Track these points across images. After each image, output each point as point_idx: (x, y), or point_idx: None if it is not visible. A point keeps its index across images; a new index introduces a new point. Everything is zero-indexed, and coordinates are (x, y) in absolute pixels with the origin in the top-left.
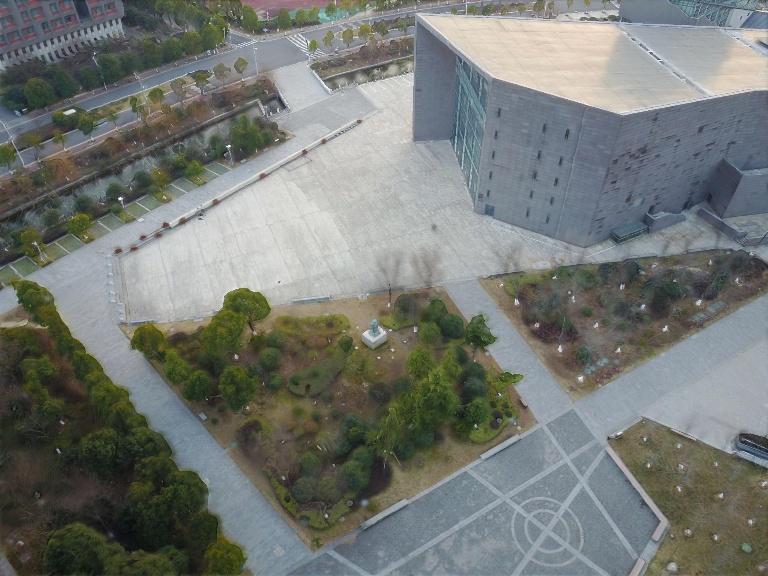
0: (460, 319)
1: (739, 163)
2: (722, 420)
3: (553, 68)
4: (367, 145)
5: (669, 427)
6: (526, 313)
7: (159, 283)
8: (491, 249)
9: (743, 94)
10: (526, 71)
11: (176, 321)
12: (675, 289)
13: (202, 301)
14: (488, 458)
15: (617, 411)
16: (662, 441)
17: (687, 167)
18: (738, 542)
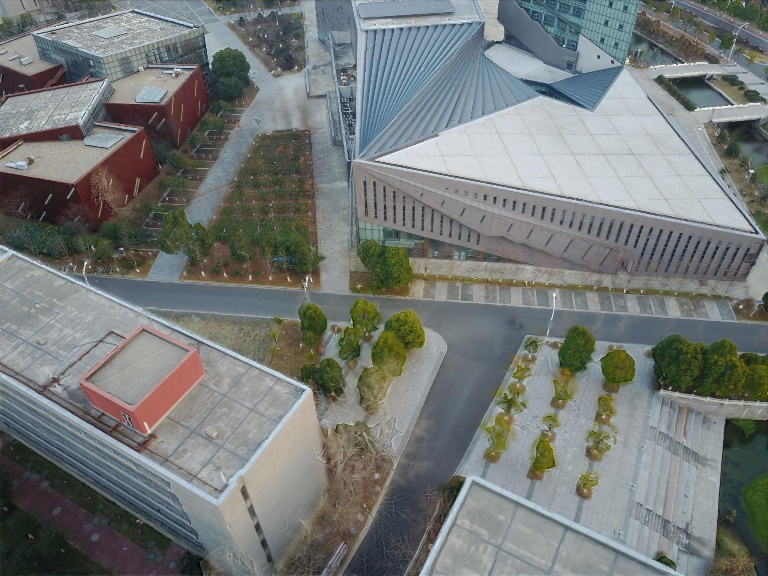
0: None
1: None
2: None
3: None
4: None
5: None
6: None
7: None
8: None
9: None
10: None
11: None
12: None
13: None
14: (208, 8)
15: (215, 28)
16: None
17: None
18: None
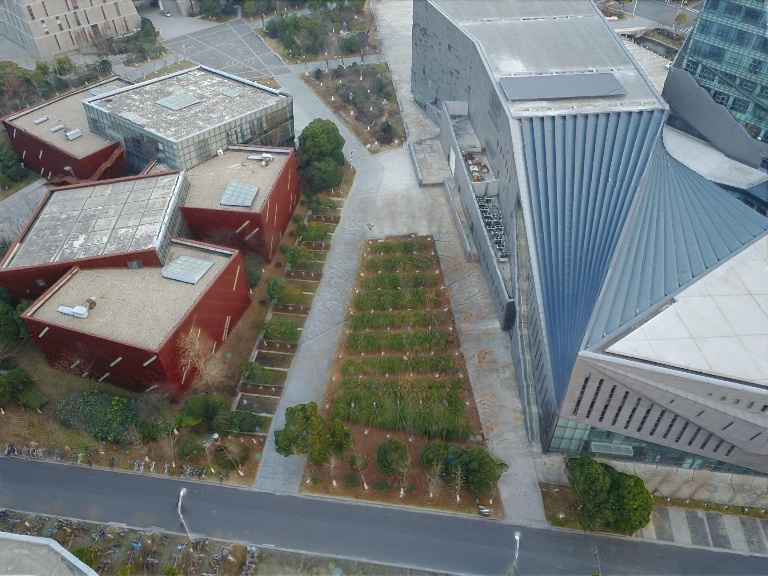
0: (345, 43)
1: None
2: None
3: None
4: None
5: None
6: None
7: (395, 4)
8: (411, 65)
9: (467, 38)
10: None
11: (370, 8)
12: None
13: (381, 11)
14: None
15: None
16: None
17: None
18: None
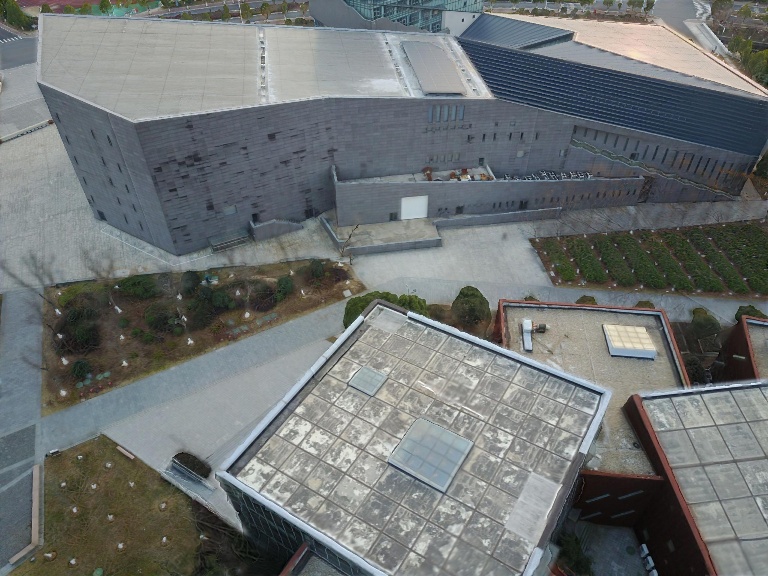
0: None
1: (354, 171)
2: (180, 438)
3: (123, 72)
4: (40, 146)
5: (119, 444)
6: (58, 323)
7: None
8: (81, 256)
9: (312, 101)
10: (87, 75)
11: None
12: (219, 301)
13: None
14: None
15: (79, 427)
16: (97, 459)
17: (281, 175)
18: (94, 567)
